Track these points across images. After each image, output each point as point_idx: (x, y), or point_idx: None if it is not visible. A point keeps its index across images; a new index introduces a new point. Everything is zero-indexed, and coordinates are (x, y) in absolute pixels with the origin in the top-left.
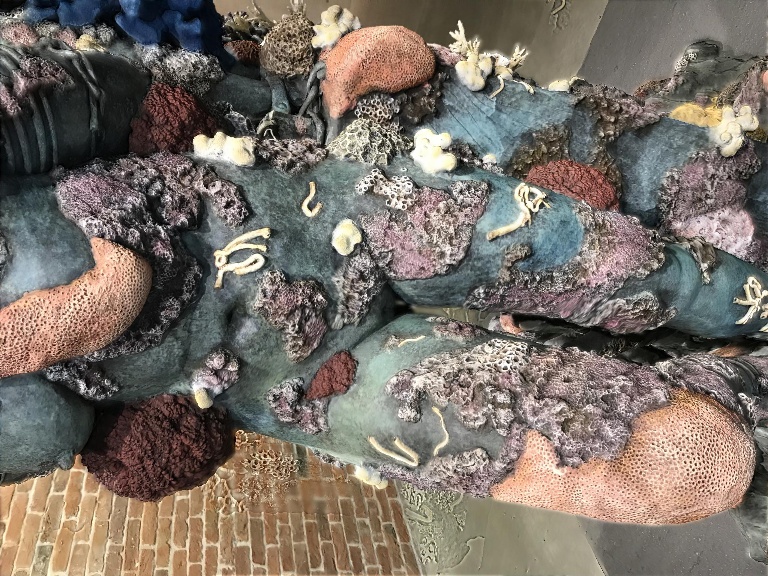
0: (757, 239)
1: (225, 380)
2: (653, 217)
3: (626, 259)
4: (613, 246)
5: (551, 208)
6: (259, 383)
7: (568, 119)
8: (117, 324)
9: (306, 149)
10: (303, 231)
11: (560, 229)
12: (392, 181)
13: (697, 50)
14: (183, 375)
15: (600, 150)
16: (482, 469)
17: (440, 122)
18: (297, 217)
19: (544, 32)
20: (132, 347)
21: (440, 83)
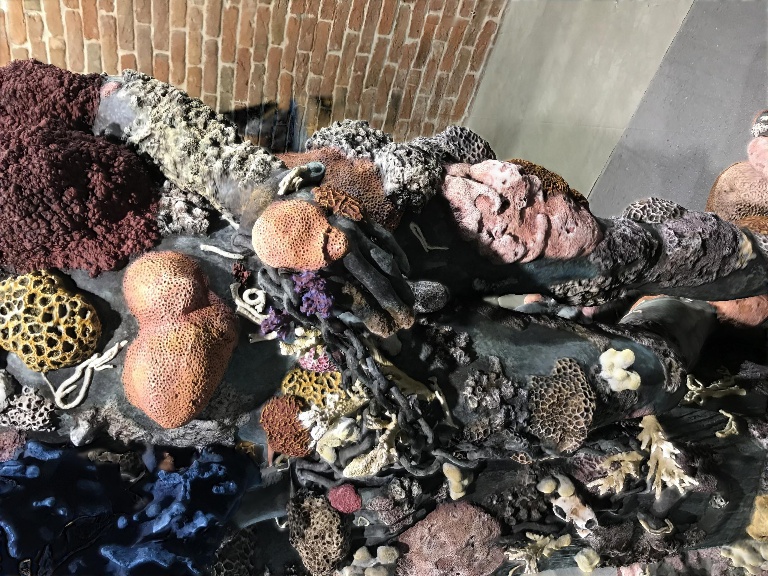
0: None
1: None
2: None
3: None
4: None
5: None
6: None
7: None
8: None
9: None
10: None
11: None
12: None
13: None
14: None
15: None
16: None
17: None
18: None
19: None
20: None
21: None
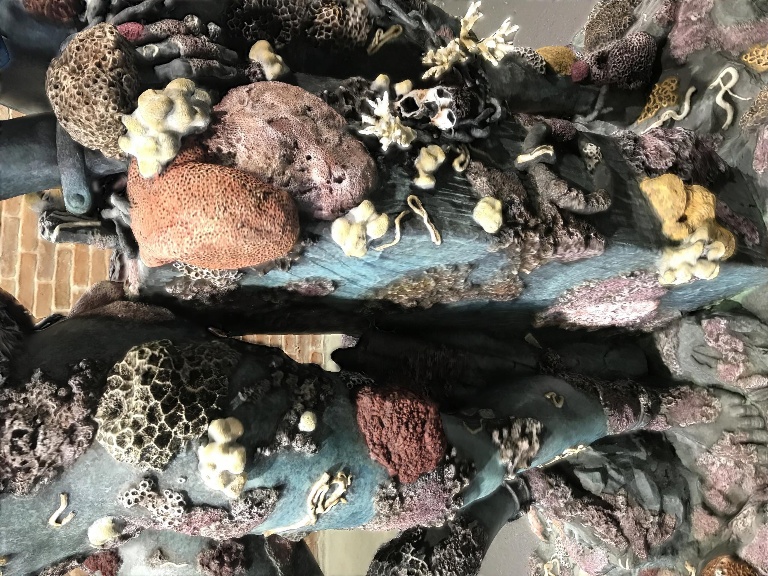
0: (655, 311)
1: None
2: (548, 303)
3: (412, 524)
4: (403, 517)
5: (347, 503)
6: None
7: (478, 259)
8: None
9: (63, 440)
10: (51, 538)
11: (348, 520)
12: (162, 498)
13: None
14: None
15: (506, 281)
16: None
17: (297, 268)
18: (43, 531)
19: None
20: None
21: (302, 247)
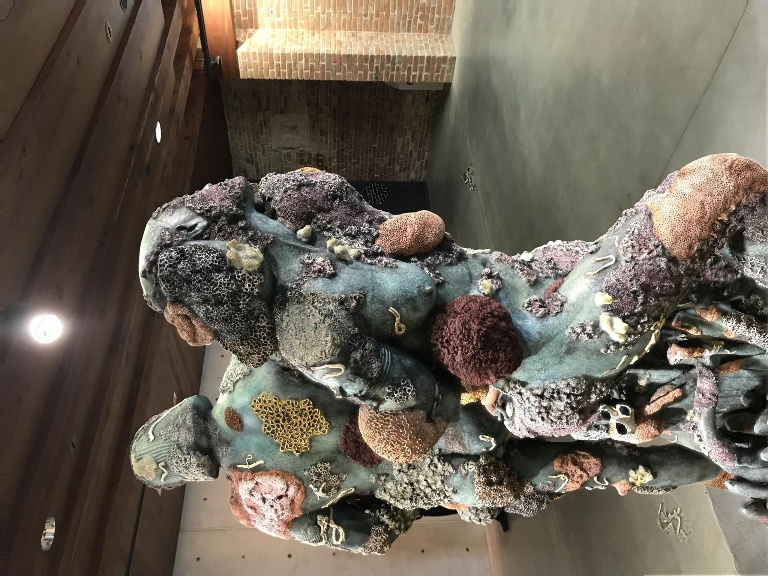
0: None
1: (495, 282)
2: None
3: None
4: None
5: None
6: (515, 295)
7: None
8: (437, 225)
9: None
10: None
11: None
12: None
13: None
14: (472, 285)
15: None
16: (639, 225)
17: None
18: None
19: (683, 551)
20: (444, 259)
21: None
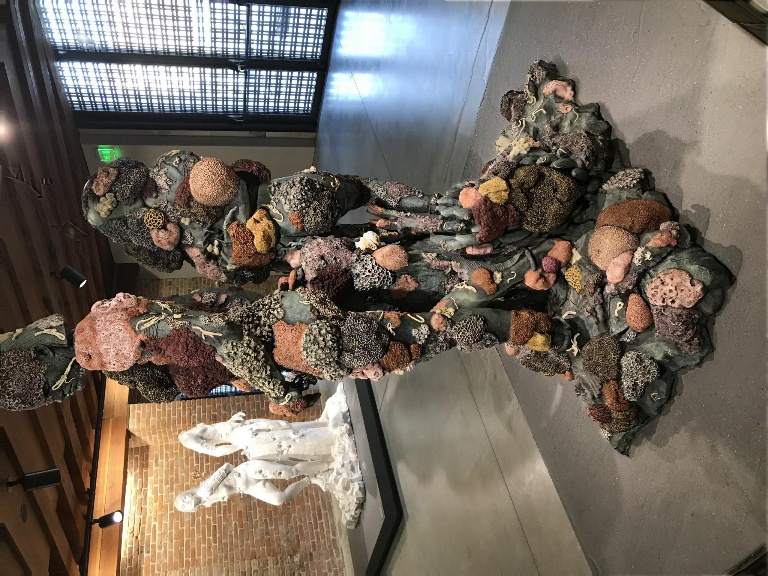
0: None
1: None
2: None
3: None
4: None
5: None
6: None
7: None
8: None
9: None
10: None
11: None
12: None
13: (605, 437)
14: None
15: None
16: None
17: None
18: None
19: None
20: None
21: None
